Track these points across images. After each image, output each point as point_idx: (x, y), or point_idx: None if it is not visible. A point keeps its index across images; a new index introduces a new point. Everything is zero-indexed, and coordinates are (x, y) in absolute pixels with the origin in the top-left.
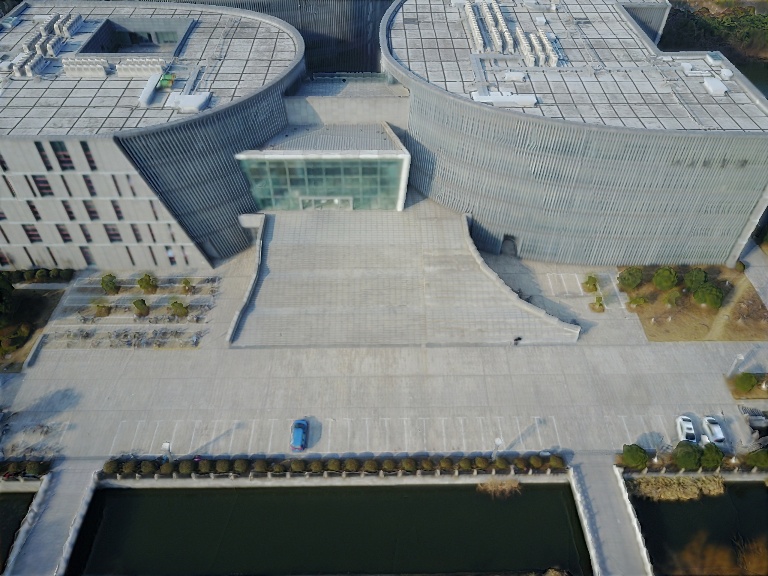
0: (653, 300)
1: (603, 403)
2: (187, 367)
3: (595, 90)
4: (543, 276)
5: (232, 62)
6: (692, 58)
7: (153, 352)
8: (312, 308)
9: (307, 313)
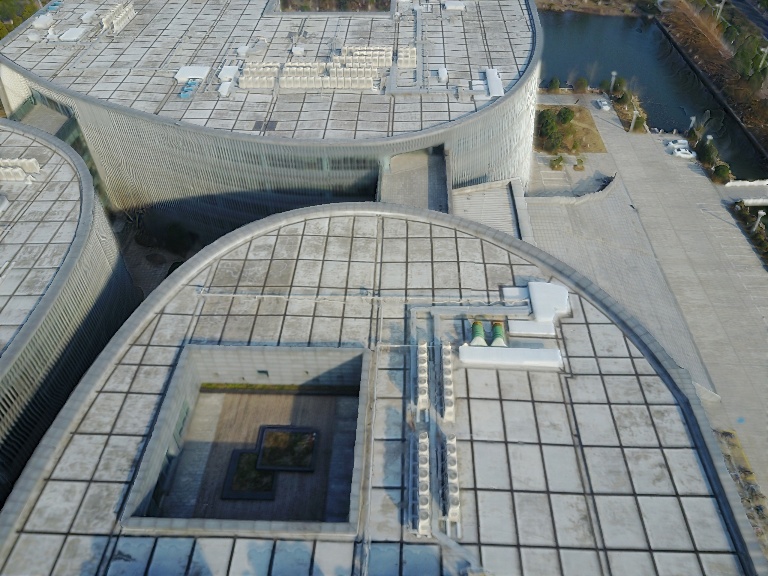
0: (563, 143)
1: (674, 181)
2: (763, 438)
3: (461, 47)
4: (547, 187)
5: (389, 278)
6: (396, 6)
7: (760, 478)
8: (653, 324)
9: (660, 328)
